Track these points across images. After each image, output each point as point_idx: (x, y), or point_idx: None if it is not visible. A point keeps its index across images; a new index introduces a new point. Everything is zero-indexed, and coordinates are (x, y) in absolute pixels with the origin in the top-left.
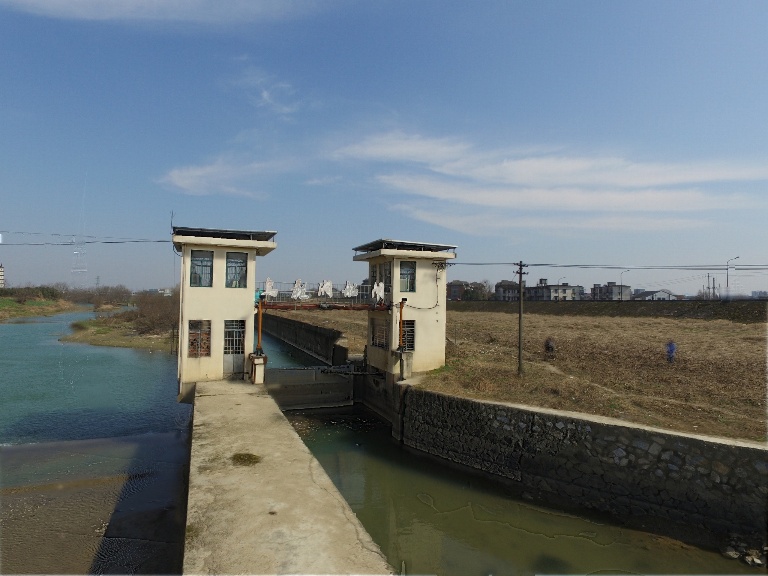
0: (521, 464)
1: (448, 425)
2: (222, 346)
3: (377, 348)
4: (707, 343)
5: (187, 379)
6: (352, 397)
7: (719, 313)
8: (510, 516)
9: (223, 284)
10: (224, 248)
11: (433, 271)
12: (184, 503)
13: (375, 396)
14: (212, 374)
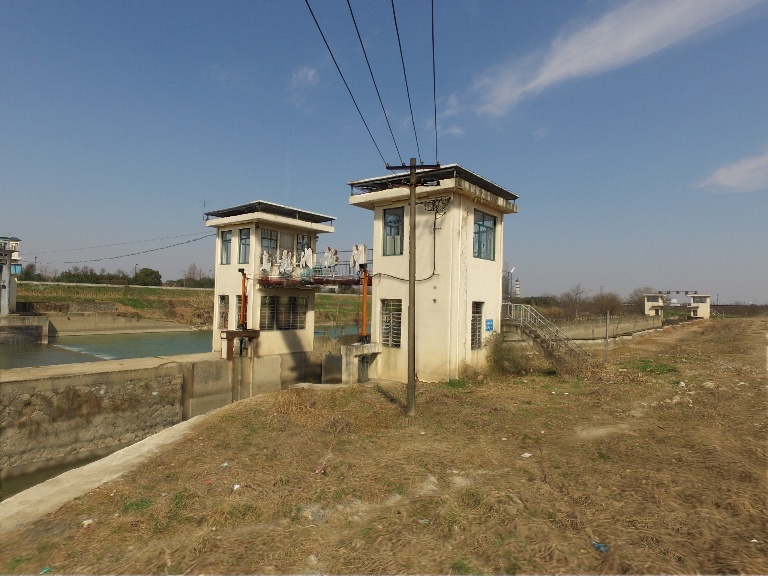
0: None
1: None
2: (234, 320)
3: None
4: None
5: (217, 348)
6: None
7: None
8: None
9: (236, 261)
10: (237, 226)
11: (430, 217)
12: None
13: None
14: None
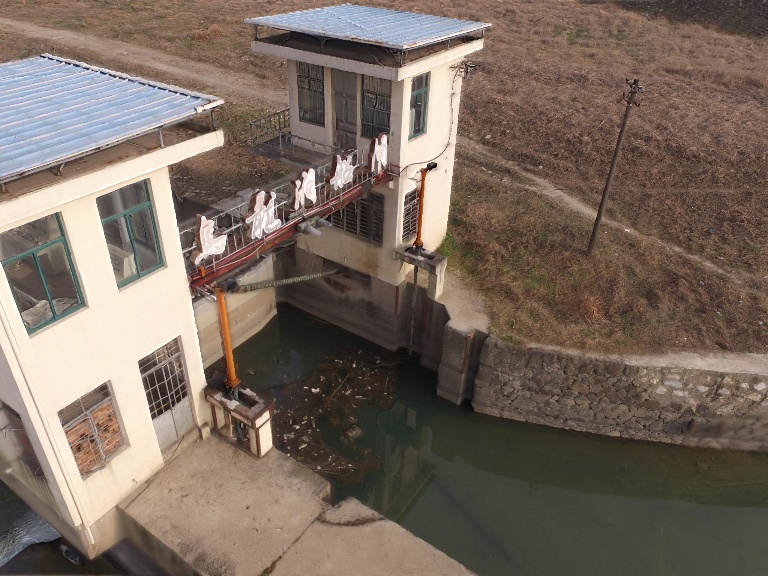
0: (692, 431)
1: (574, 393)
2: (147, 412)
3: (337, 232)
4: (659, 95)
5: (97, 514)
6: (275, 303)
7: None
8: (653, 476)
9: (112, 286)
10: None
11: (448, 81)
12: None
13: (334, 304)
14: (142, 471)
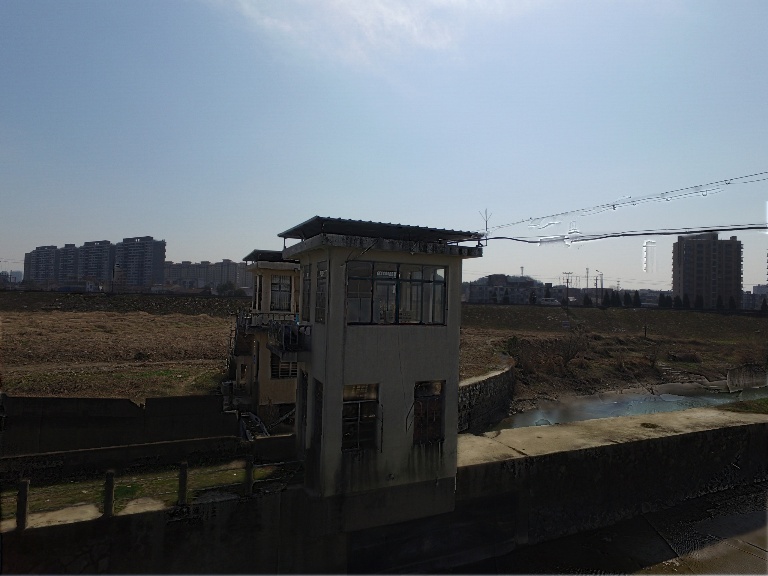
0: None
1: None
2: None
3: None
4: None
5: None
6: None
7: (119, 305)
8: None
9: None
10: None
11: None
12: (693, 445)
13: None
14: None
